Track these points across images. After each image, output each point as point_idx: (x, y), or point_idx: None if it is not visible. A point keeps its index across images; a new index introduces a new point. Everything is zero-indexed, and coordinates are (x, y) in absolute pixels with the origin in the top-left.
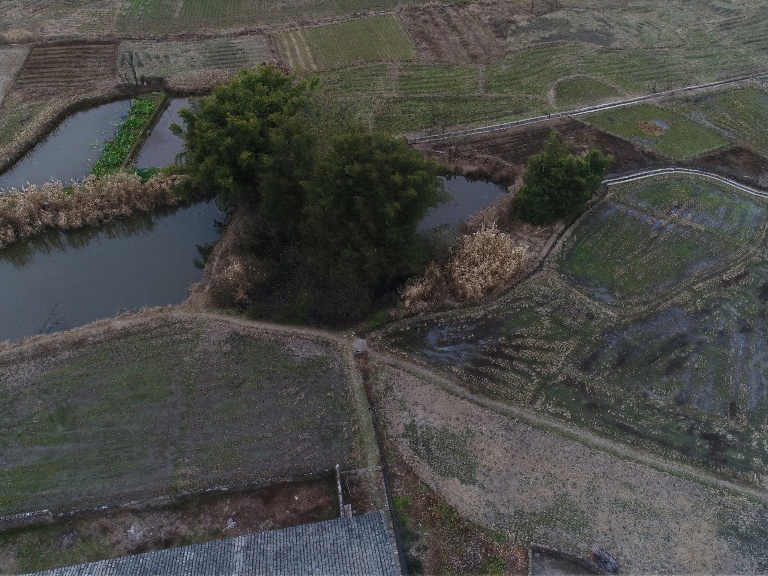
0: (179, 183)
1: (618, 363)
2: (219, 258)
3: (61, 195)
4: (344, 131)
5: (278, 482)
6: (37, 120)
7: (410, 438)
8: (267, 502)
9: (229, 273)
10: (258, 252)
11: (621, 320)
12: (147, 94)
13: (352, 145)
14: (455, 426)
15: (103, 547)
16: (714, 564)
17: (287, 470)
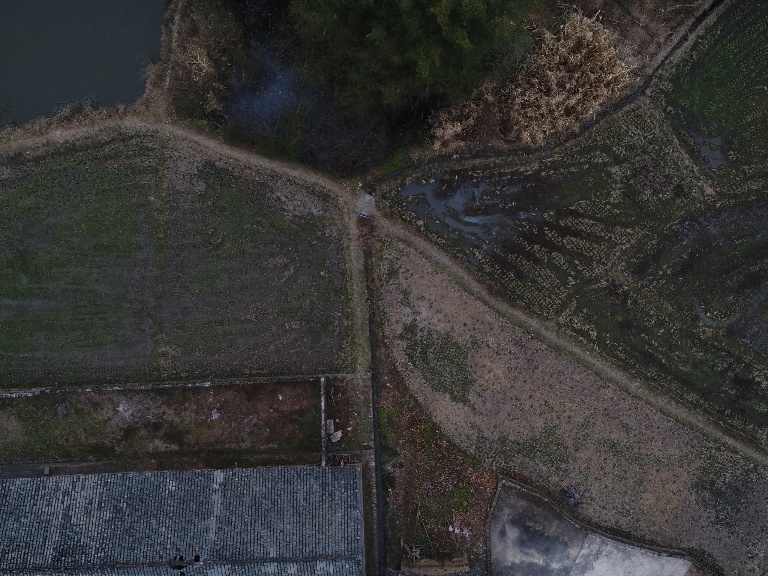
0: None
1: (683, 269)
2: (180, 18)
3: None
4: None
5: None
6: None
7: (407, 341)
8: (251, 398)
9: (193, 68)
10: (236, 6)
11: (717, 201)
12: None
13: None
14: (460, 333)
15: (96, 422)
16: (673, 513)
17: (272, 363)
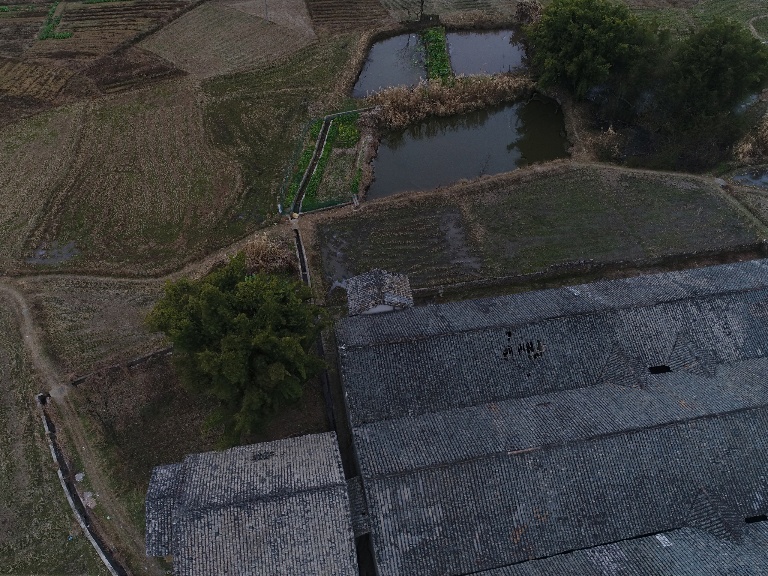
0: (545, 75)
1: None
2: (577, 132)
3: (441, 89)
4: (710, 24)
5: (725, 251)
6: (361, 45)
7: None
8: (723, 262)
9: (604, 137)
10: (600, 130)
11: None
12: (429, 28)
13: (722, 32)
14: None
15: None
16: None
17: None
